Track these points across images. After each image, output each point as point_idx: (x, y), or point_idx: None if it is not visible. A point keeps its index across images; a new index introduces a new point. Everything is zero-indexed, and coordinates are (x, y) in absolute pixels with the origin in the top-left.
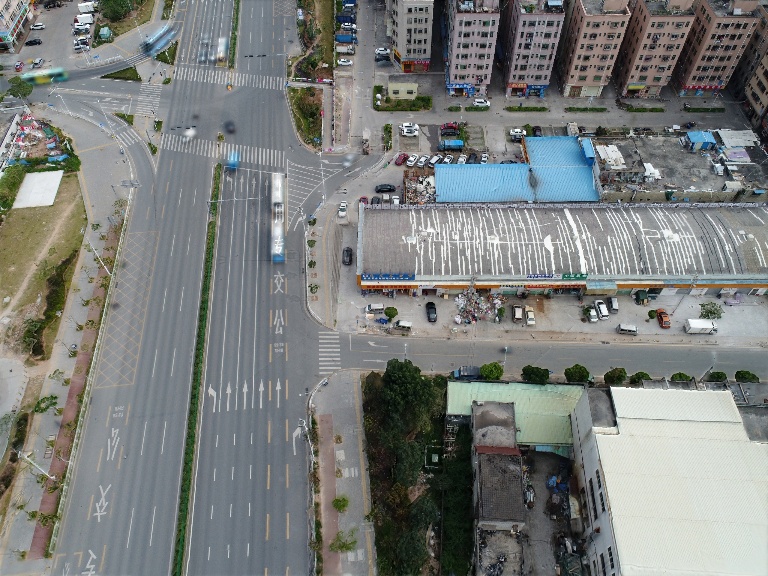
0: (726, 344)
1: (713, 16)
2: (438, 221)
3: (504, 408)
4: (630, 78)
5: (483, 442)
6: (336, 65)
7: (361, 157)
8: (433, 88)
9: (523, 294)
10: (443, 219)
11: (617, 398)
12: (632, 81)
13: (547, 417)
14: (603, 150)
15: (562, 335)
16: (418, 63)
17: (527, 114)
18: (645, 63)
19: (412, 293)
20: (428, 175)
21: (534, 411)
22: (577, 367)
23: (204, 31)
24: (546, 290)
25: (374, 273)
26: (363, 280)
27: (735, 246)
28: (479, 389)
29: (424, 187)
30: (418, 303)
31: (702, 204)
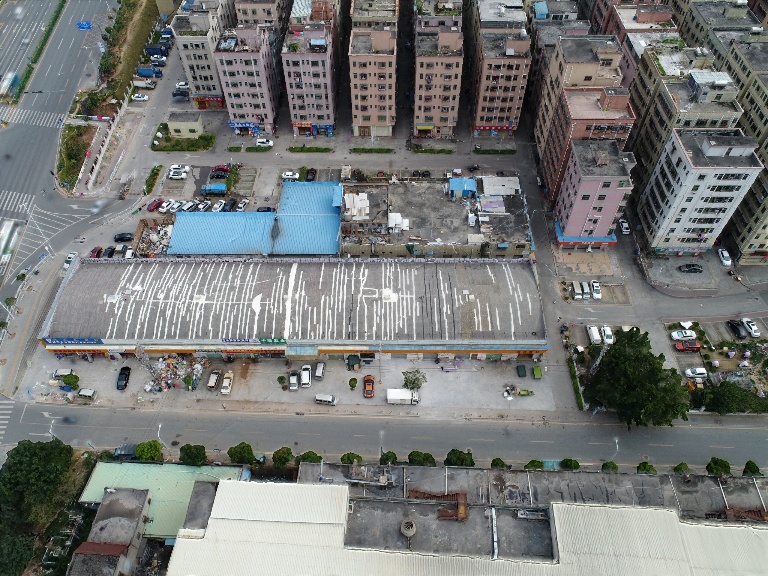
0: (428, 416)
1: (484, 57)
2: (151, 277)
3: (137, 496)
4: (416, 118)
5: (98, 537)
6: (129, 100)
7: (116, 202)
8: (222, 126)
9: (229, 358)
10: (158, 275)
11: (220, 494)
12: (419, 121)
13: (187, 505)
14: (351, 199)
15: (256, 405)
16: (210, 99)
17: (309, 155)
18: (426, 103)
19: (110, 356)
20: (167, 224)
21: (175, 498)
22: (240, 446)
23: (3, 63)
24: (251, 354)
25: (62, 336)
26: (49, 344)
27: (454, 307)
28: (127, 471)
29: (160, 237)
30: (115, 367)
31: (438, 259)
